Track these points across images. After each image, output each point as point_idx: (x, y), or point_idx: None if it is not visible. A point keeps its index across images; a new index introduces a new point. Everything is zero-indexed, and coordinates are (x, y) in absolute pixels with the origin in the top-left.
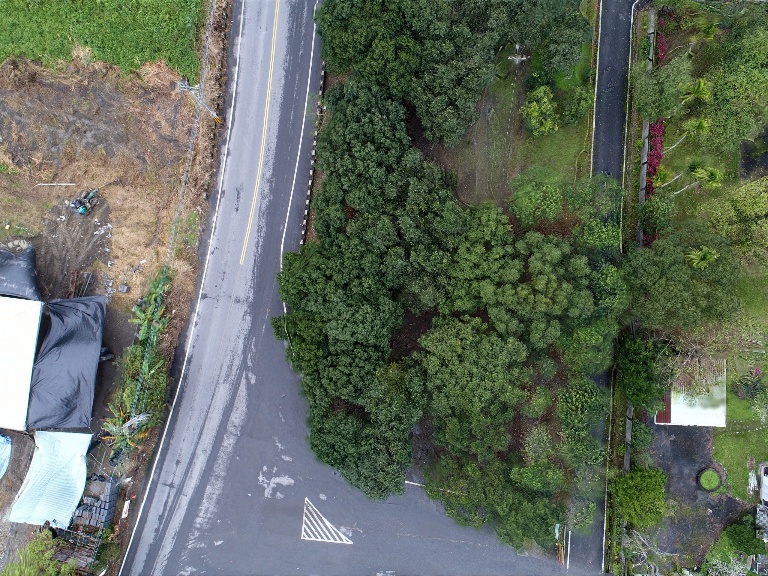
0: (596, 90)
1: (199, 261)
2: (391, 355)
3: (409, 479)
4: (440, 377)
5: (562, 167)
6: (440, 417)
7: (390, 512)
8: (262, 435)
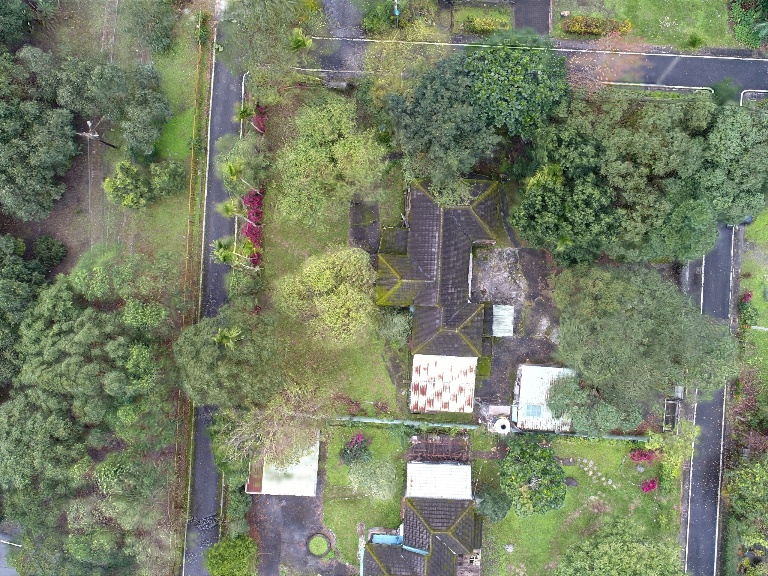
0: (208, 160)
1: None
2: None
3: None
4: None
5: (174, 236)
6: (5, 491)
7: None
8: None
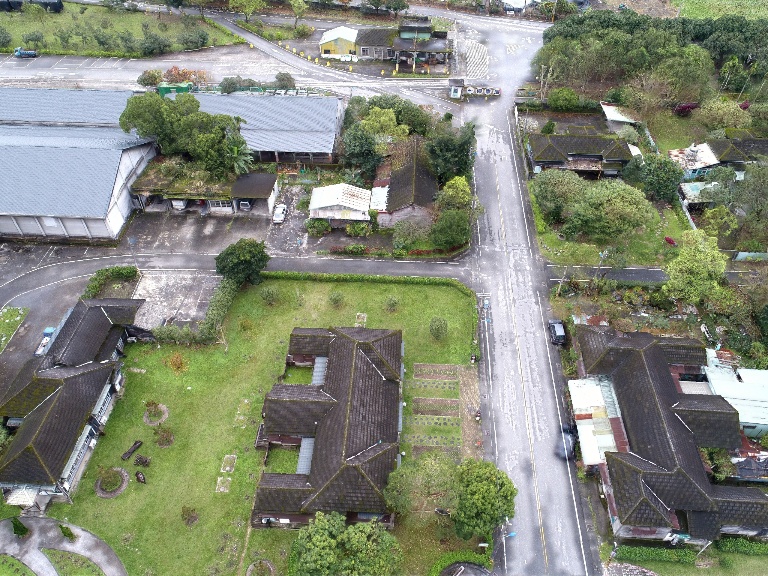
0: None
1: None
2: None
3: None
4: None
5: None
6: None
7: None
8: None
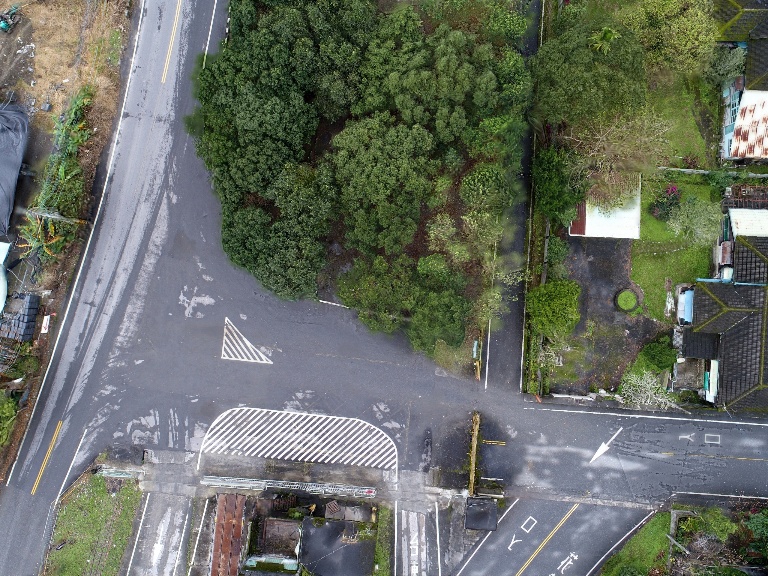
0: None
1: (121, 80)
2: (305, 159)
3: (329, 299)
4: (347, 167)
5: None
6: (350, 214)
7: (310, 332)
8: (183, 255)
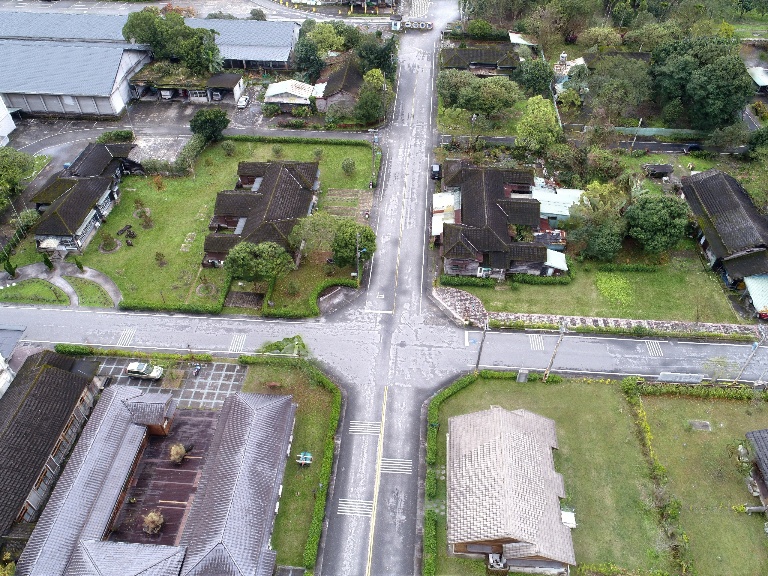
0: None
1: None
2: None
3: None
4: None
5: None
6: None
7: None
8: None
